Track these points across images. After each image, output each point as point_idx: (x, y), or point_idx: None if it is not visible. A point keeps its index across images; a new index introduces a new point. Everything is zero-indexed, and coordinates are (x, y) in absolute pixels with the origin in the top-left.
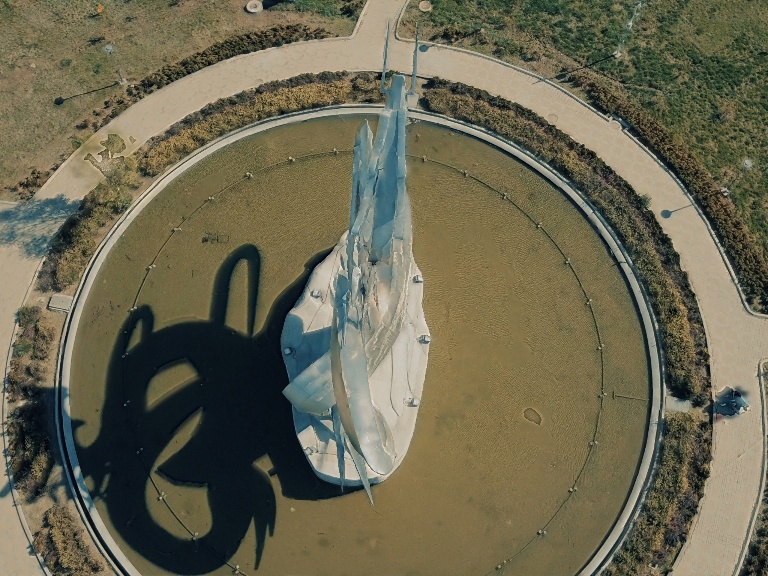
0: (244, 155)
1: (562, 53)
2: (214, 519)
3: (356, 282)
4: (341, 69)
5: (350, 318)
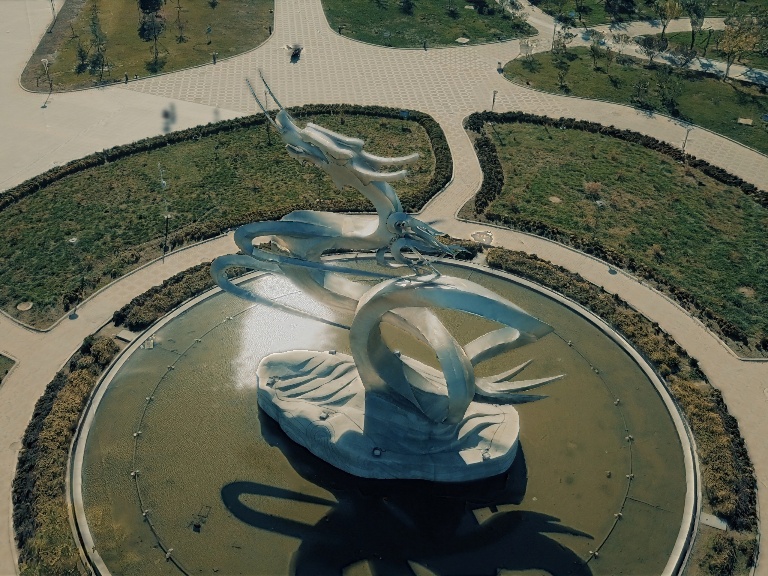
0: (104, 476)
1: (143, 243)
2: (538, 568)
3: (425, 223)
4: (52, 377)
5: (428, 281)
